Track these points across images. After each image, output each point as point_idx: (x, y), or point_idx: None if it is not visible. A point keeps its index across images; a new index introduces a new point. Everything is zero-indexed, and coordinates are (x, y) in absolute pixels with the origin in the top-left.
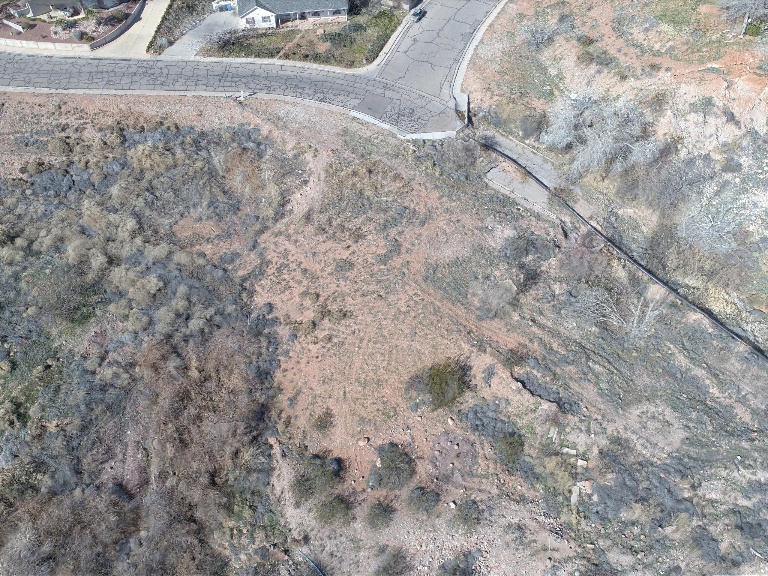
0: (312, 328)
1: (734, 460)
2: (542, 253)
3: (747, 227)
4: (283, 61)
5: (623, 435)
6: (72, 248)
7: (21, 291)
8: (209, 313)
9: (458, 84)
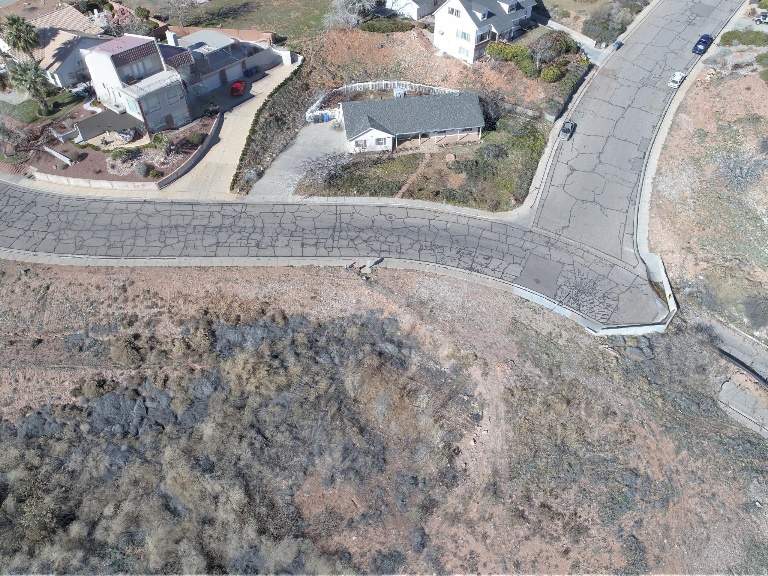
0: None
1: None
2: None
3: None
4: (407, 201)
5: None
6: (154, 543)
7: None
8: None
9: (643, 238)
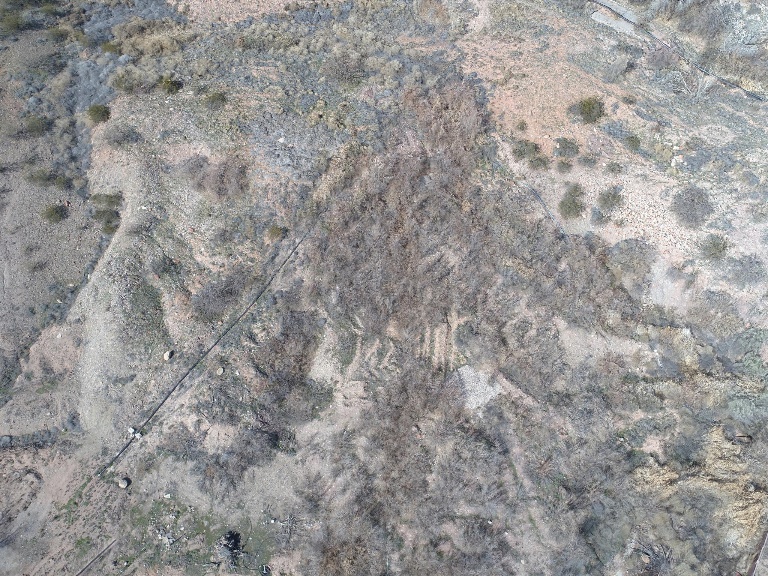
0: (506, 81)
1: (765, 145)
2: (635, 55)
3: (765, 47)
4: None
5: (698, 137)
6: (337, 48)
7: (311, 70)
8: (437, 77)
9: None
